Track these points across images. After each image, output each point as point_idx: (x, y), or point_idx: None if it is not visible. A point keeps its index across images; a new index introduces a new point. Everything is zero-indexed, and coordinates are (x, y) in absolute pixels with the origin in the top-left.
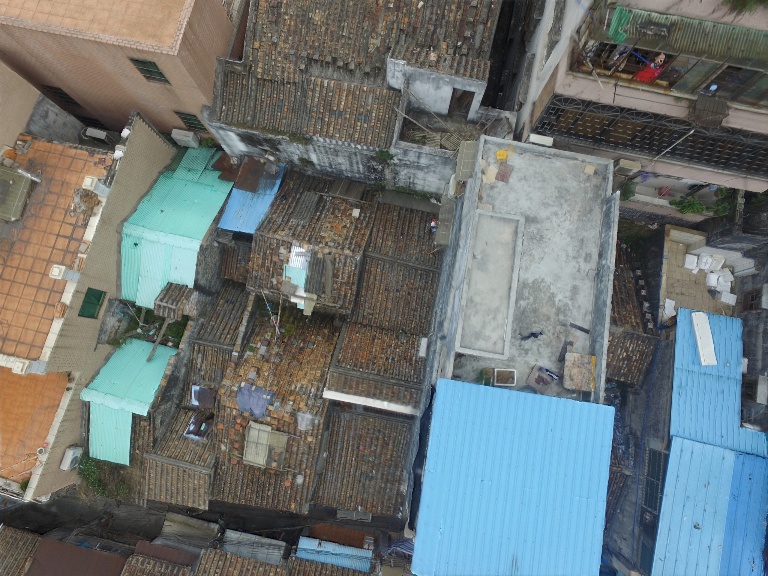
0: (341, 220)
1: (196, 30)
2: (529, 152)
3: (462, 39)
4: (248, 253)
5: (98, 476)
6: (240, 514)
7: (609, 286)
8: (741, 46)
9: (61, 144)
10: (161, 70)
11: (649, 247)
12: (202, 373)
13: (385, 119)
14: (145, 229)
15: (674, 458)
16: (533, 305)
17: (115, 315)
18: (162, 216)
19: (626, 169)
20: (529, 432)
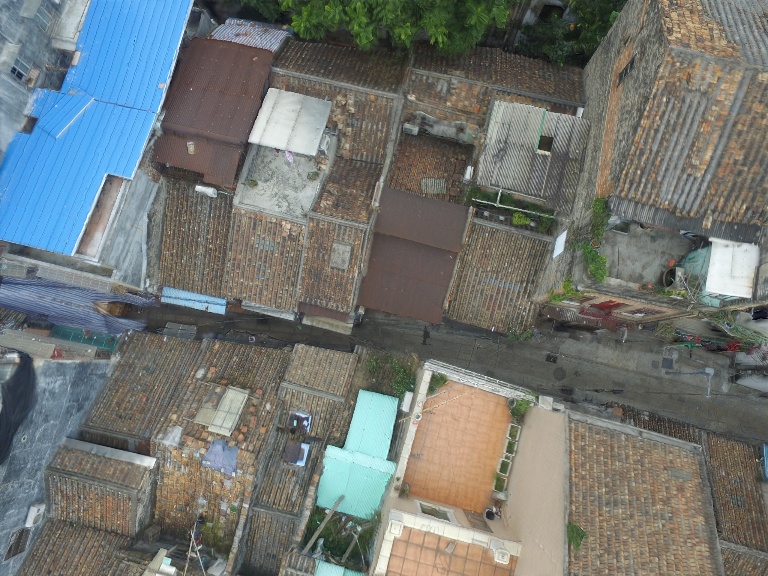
0: None
1: None
2: None
3: None
4: None
5: None
6: None
7: None
8: None
9: None
10: None
11: None
12: (295, 478)
13: None
14: None
15: None
16: None
17: None
18: None
19: None
20: None
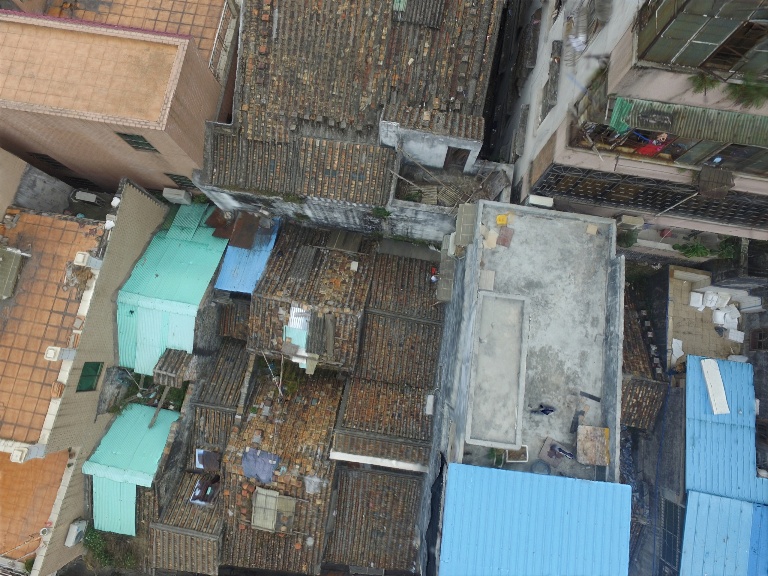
0: (340, 275)
1: (183, 100)
2: (529, 214)
3: (455, 94)
4: (246, 310)
5: (104, 547)
6: (251, 568)
7: (619, 356)
8: (747, 133)
9: (50, 216)
10: (149, 142)
11: (653, 286)
12: (205, 436)
13: (380, 176)
14: (140, 296)
15: (691, 513)
16: (541, 374)
17: (114, 382)
18: (157, 281)
19: (629, 225)
20: (545, 516)
